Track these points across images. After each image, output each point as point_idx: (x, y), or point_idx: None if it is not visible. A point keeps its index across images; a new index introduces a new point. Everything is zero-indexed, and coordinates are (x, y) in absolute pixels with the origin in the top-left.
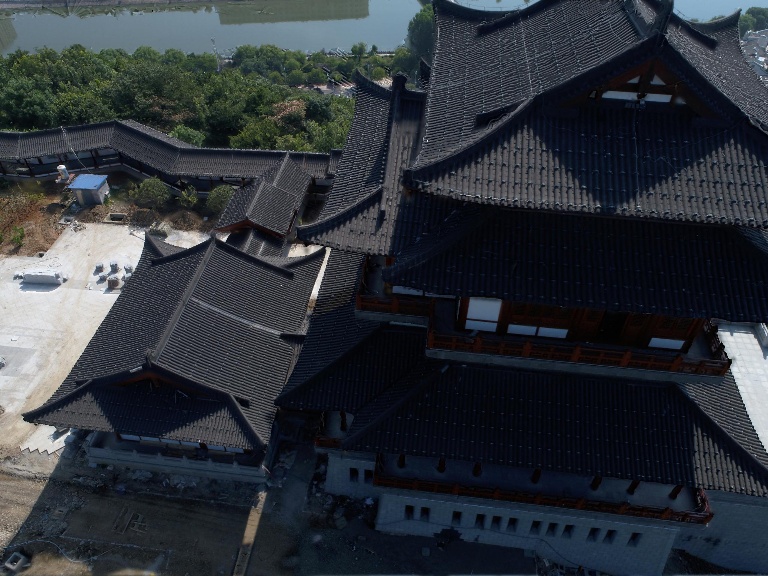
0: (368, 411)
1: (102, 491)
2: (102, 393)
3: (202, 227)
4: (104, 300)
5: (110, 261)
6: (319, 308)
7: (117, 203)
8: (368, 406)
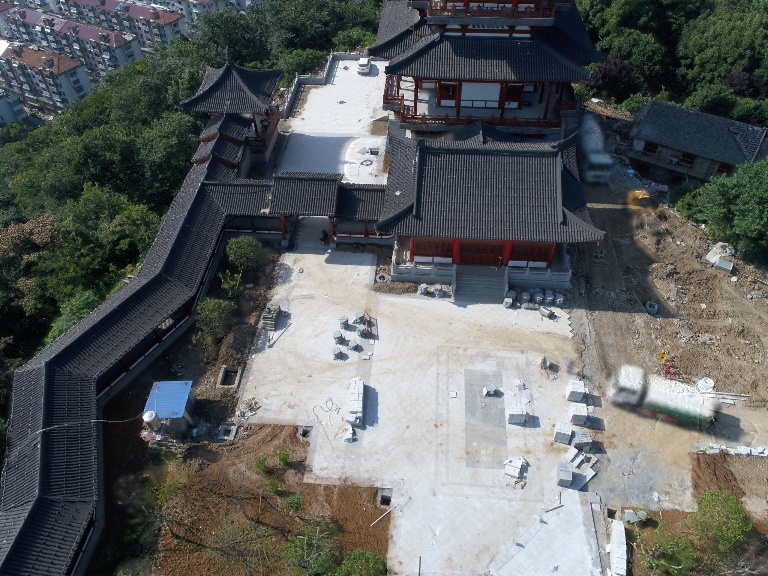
0: (579, 57)
1: (585, 279)
2: (566, 207)
3: (265, 286)
4: (389, 336)
5: (323, 351)
6: (507, 76)
7: (194, 386)
8: (576, 58)
